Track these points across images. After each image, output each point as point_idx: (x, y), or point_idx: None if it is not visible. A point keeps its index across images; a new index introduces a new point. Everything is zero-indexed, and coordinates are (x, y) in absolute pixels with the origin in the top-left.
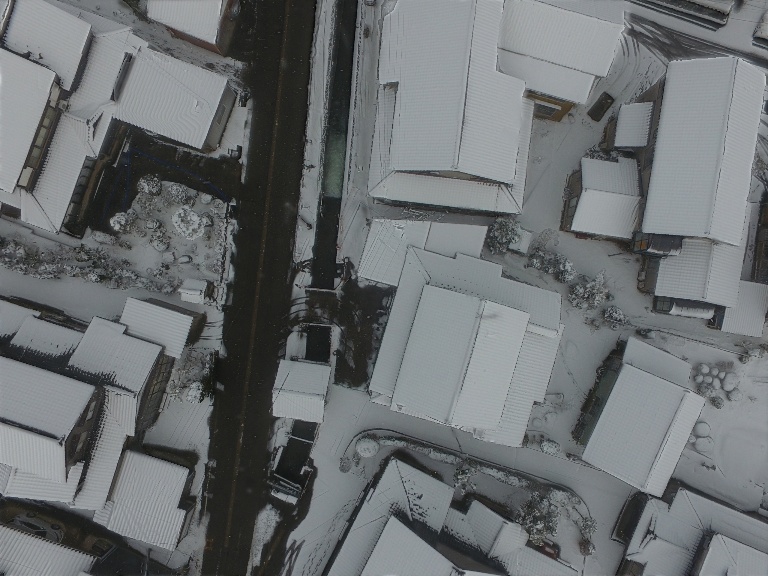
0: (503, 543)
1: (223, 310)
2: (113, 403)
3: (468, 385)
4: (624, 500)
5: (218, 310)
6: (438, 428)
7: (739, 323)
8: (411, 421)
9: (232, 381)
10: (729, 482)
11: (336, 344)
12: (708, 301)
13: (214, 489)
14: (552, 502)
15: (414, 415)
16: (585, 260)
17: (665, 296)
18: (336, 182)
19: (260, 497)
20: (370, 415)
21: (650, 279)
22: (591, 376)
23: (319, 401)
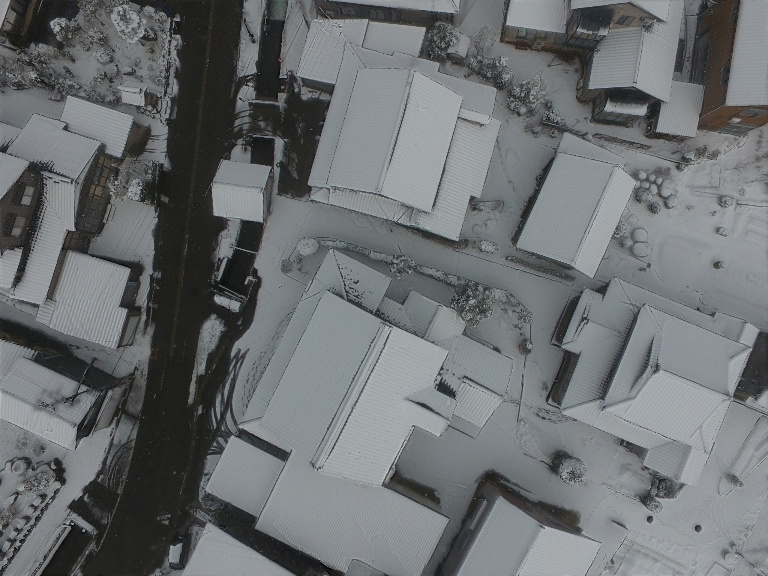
0: (438, 327)
1: (167, 124)
2: (52, 193)
3: (398, 156)
4: (563, 305)
5: (162, 124)
6: (380, 236)
7: (674, 123)
8: (353, 229)
9: (176, 193)
10: (666, 286)
11: (279, 155)
12: (639, 88)
13: (159, 299)
14: (492, 306)
15: (352, 208)
16: (525, 71)
17: (599, 89)
18: (281, 5)
19: (205, 307)
20: (313, 225)
21: (587, 83)
22: (531, 184)
23: (258, 194)
